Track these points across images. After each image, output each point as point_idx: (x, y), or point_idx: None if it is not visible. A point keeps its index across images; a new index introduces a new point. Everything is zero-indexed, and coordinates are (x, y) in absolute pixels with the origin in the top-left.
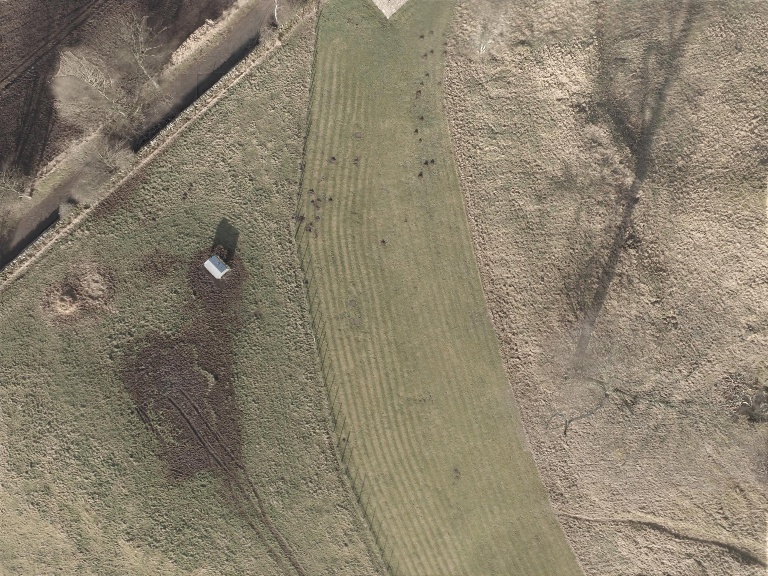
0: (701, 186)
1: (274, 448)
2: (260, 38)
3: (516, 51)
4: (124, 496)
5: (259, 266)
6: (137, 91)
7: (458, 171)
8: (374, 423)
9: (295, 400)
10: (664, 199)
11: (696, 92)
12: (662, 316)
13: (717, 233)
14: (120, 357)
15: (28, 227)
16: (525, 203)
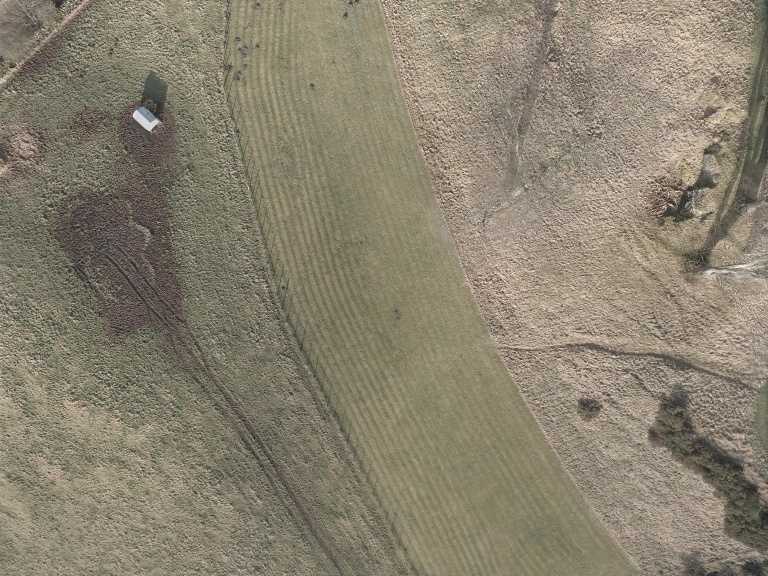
0: None
1: (214, 300)
2: None
3: None
4: (66, 355)
5: (189, 118)
6: None
7: (383, 8)
8: (312, 269)
9: (232, 251)
10: (582, 8)
11: None
12: (586, 127)
13: (634, 34)
14: (54, 216)
15: None
16: (450, 34)
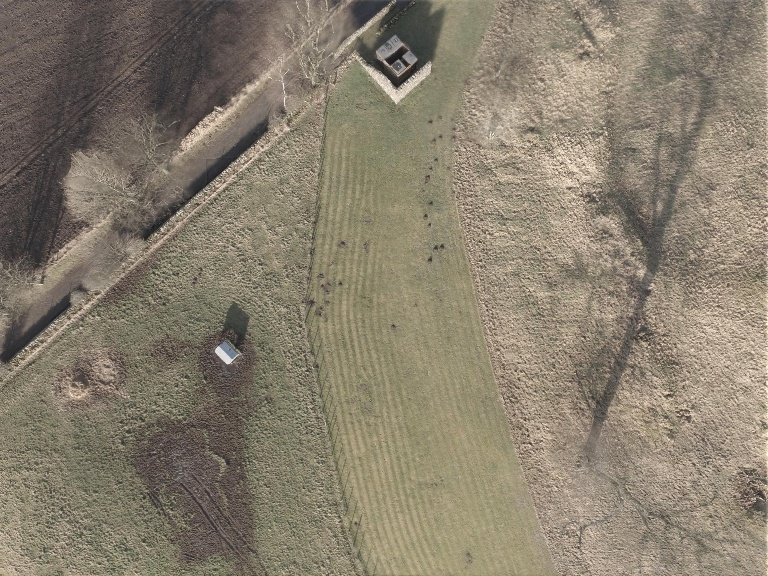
0: (714, 281)
1: (286, 532)
2: (269, 125)
3: (525, 138)
4: None
5: (269, 350)
6: (147, 178)
7: (468, 256)
8: (386, 507)
9: (306, 484)
10: (676, 292)
11: (707, 186)
12: (675, 409)
13: (730, 329)
14: (132, 442)
15: (39, 313)
16: (536, 289)
